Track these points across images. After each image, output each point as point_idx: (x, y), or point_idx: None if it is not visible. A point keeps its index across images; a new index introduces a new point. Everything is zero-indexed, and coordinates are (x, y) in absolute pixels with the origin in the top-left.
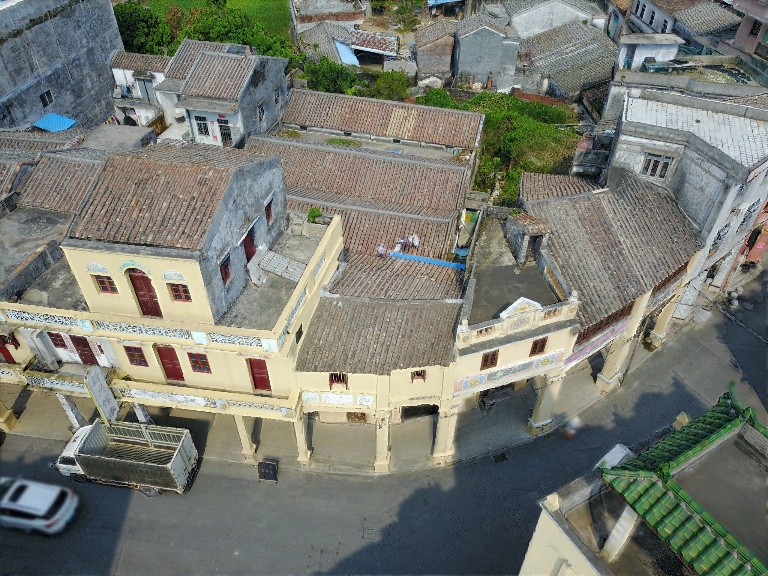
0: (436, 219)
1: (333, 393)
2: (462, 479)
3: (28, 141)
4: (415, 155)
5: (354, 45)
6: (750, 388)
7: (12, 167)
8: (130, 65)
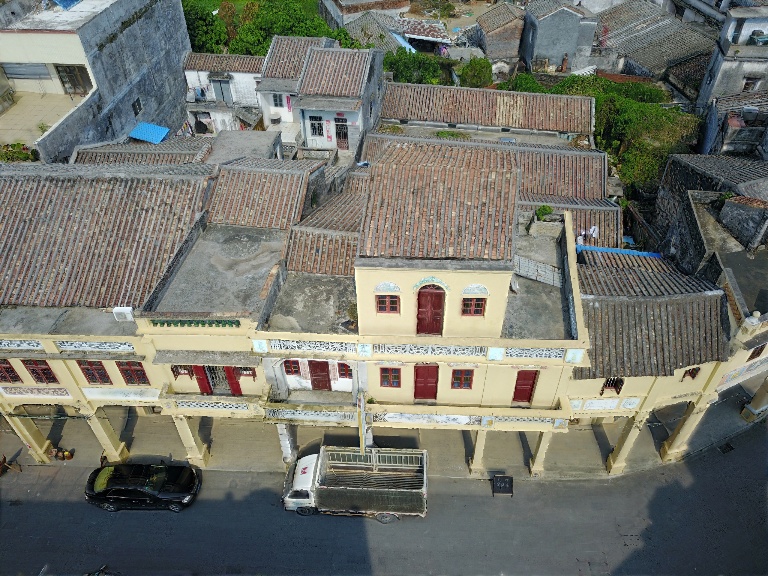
0: (603, 208)
1: (599, 399)
2: (698, 474)
3: (153, 153)
4: (531, 143)
5: (407, 34)
6: None
7: (198, 183)
8: (205, 66)
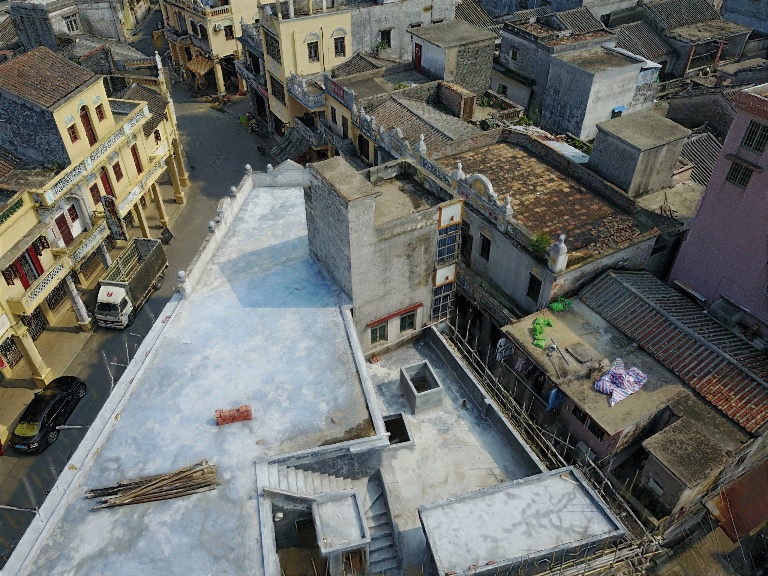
0: None
1: (157, 149)
2: (200, 179)
3: None
4: None
5: None
6: (186, 103)
7: None
8: None
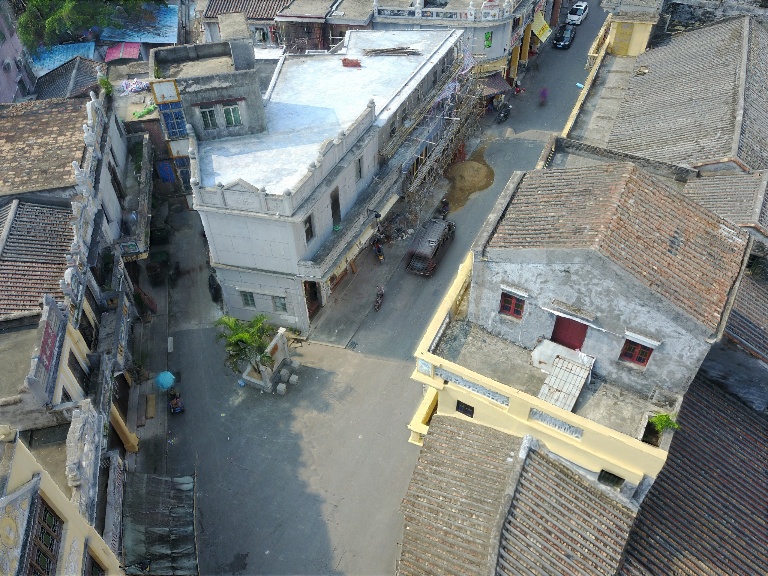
0: None
1: None
2: None
3: None
4: None
5: None
6: None
7: None
8: None
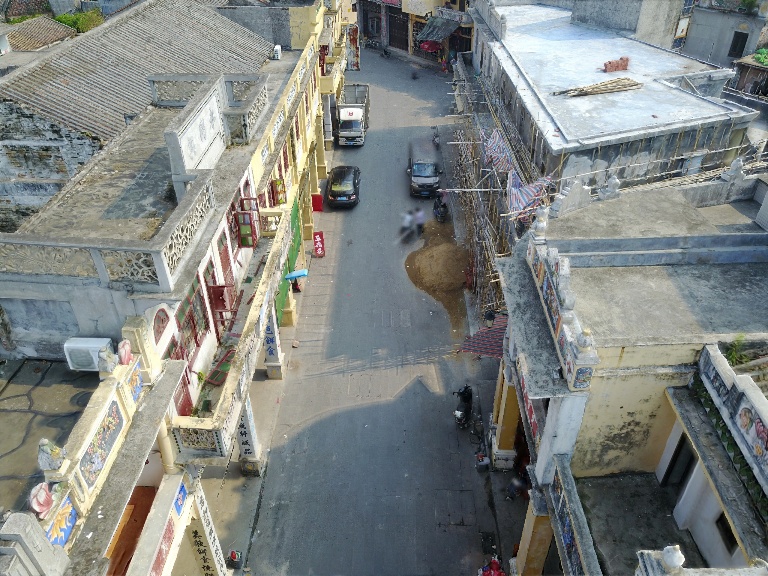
0: None
1: None
2: (345, 73)
3: None
4: None
5: None
6: None
7: None
8: None
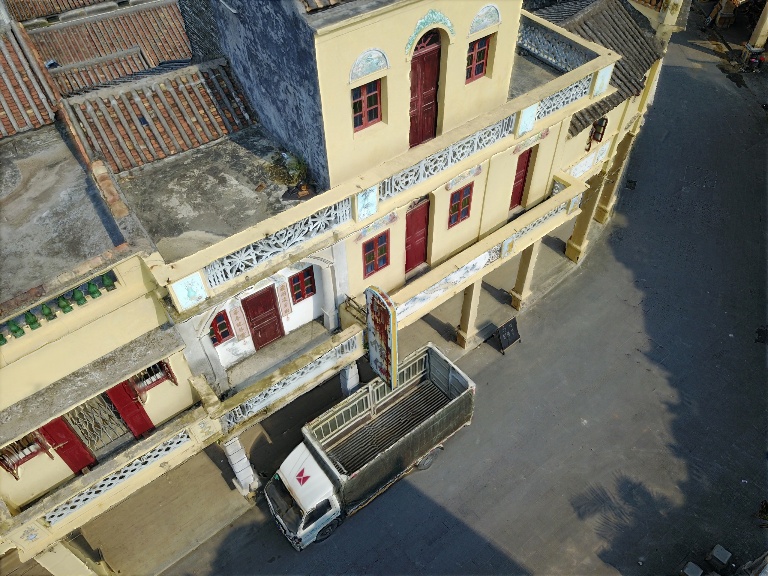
0: None
1: (582, 160)
2: (634, 217)
3: None
4: None
5: None
6: (678, 45)
7: None
8: None
